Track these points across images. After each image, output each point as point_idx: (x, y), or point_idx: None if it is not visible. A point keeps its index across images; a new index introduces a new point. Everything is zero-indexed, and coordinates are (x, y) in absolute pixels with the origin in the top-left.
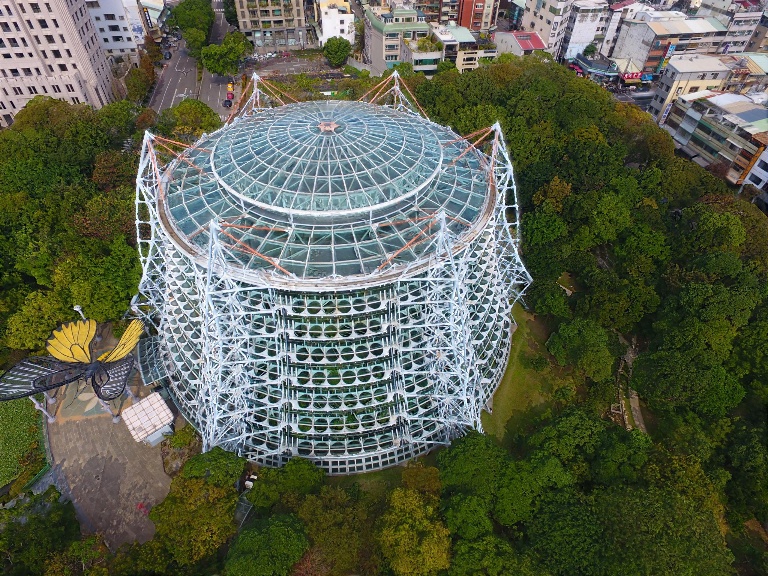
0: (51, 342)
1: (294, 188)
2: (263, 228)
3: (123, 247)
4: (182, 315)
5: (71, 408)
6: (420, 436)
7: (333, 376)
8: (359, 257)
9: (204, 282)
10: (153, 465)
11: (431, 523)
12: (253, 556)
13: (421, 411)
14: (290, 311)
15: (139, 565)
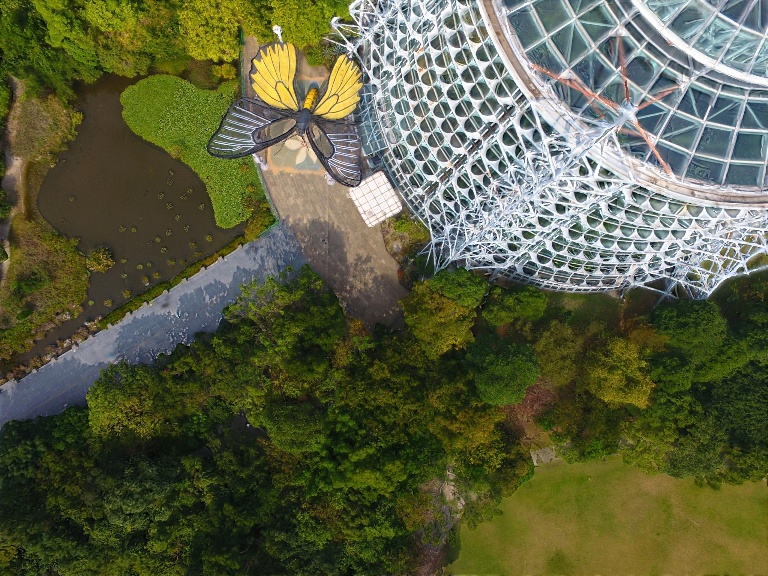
0: (255, 77)
1: (738, 13)
2: (666, 94)
3: None
4: (437, 103)
5: (281, 156)
6: (644, 280)
7: (608, 236)
8: (766, 158)
9: (522, 119)
10: (375, 241)
11: None
12: (504, 383)
13: (664, 267)
14: (629, 199)
15: (404, 360)
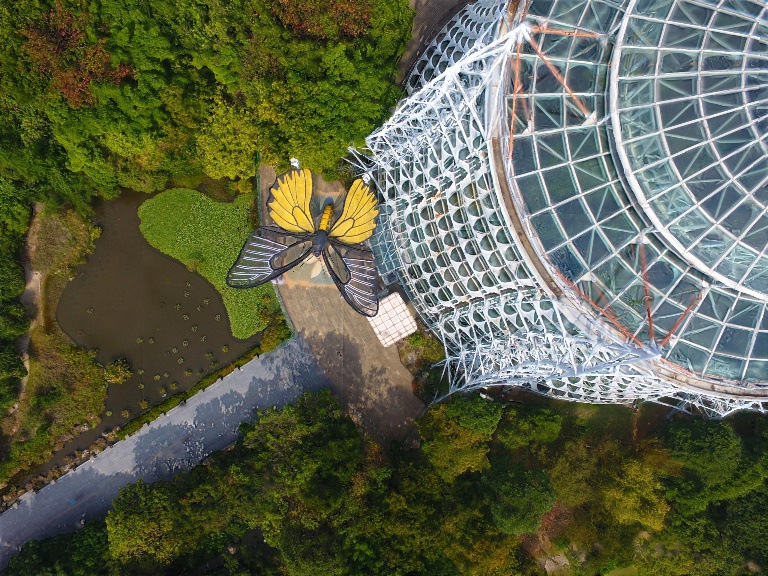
0: (272, 206)
1: (758, 242)
2: None
3: (341, 63)
4: (454, 247)
5: (296, 270)
6: None
7: None
8: None
9: None
10: (389, 352)
11: (655, 494)
12: (521, 515)
13: None
14: None
15: (421, 487)
